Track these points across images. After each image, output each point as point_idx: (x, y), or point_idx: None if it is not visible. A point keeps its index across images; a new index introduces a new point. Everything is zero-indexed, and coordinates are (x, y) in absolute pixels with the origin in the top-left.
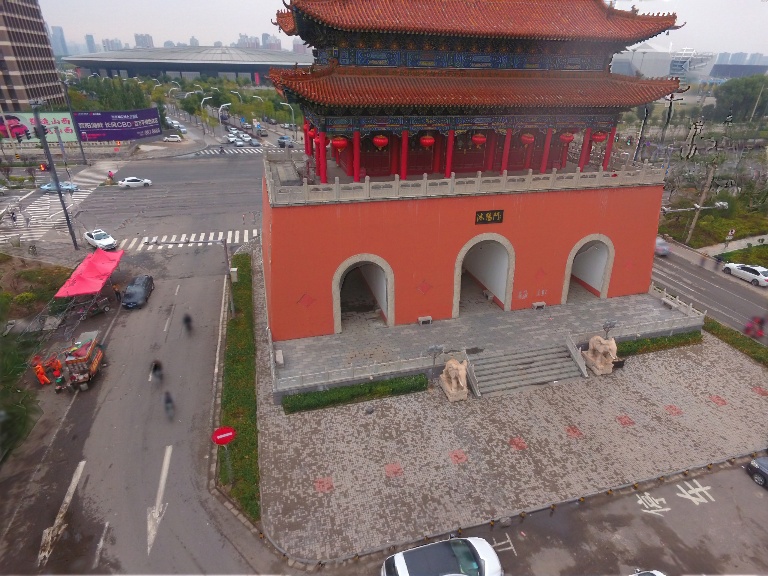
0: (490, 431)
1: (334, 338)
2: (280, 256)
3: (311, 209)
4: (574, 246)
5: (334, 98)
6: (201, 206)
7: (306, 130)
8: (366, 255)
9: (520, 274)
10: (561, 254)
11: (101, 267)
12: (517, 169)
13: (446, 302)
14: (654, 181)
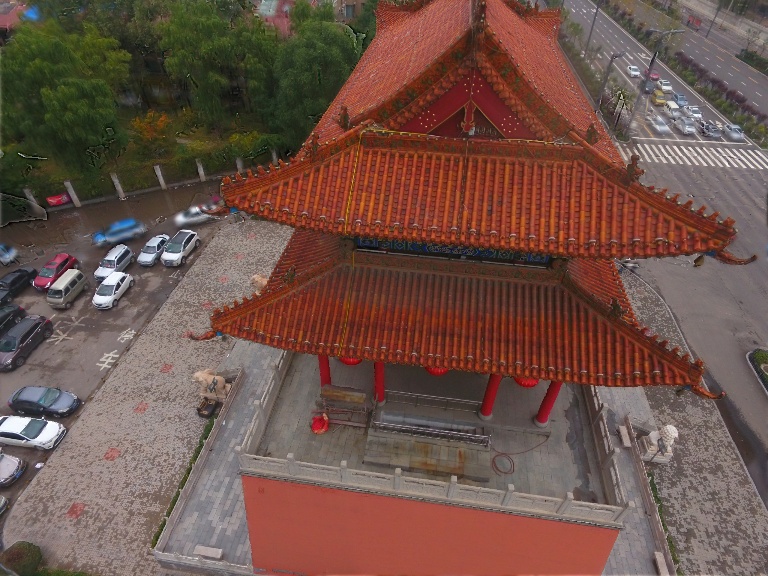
0: (225, 298)
1: None
2: None
3: None
4: None
5: None
6: None
7: None
8: None
9: None
10: None
11: None
12: None
13: None
14: None
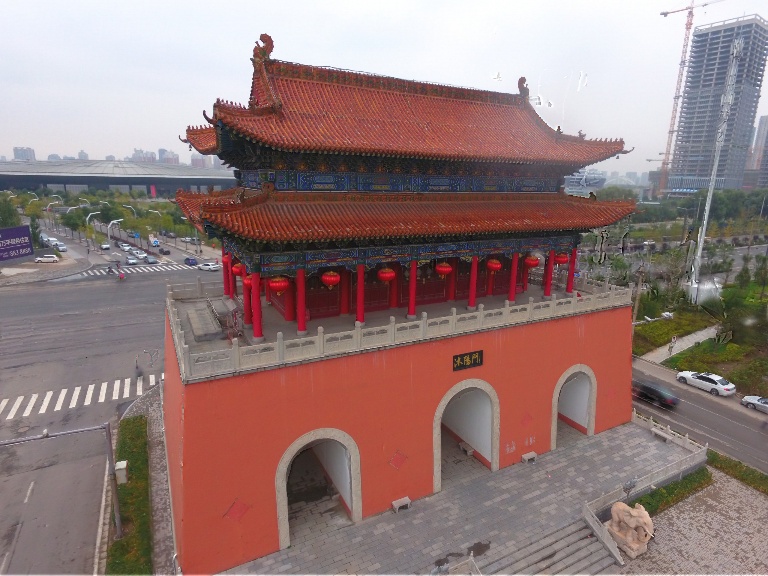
0: None
1: (280, 560)
2: (197, 452)
3: (244, 379)
4: (558, 381)
5: (274, 232)
6: (78, 346)
7: (226, 263)
8: (321, 431)
9: (505, 423)
10: (545, 392)
11: None
12: (479, 296)
13: (425, 474)
14: (623, 302)
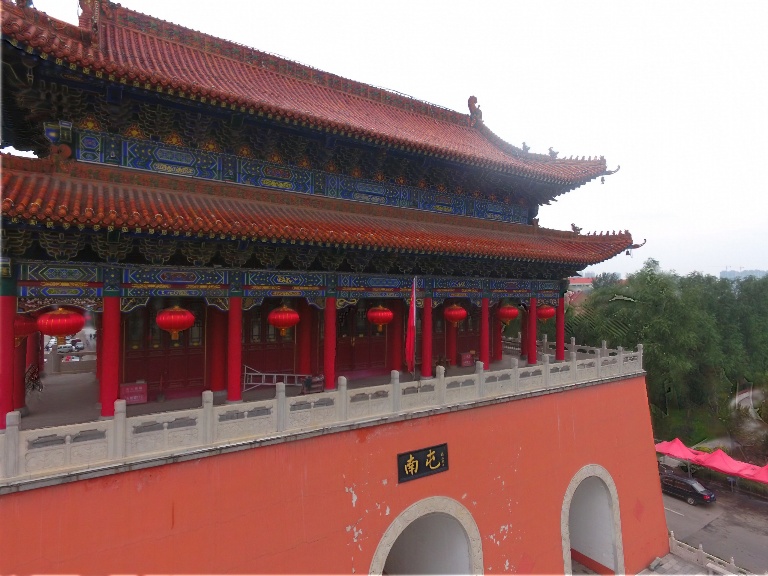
0: None
1: None
2: None
3: None
4: None
5: None
6: None
7: None
8: None
9: None
10: None
11: (713, 459)
12: None
13: None
14: None
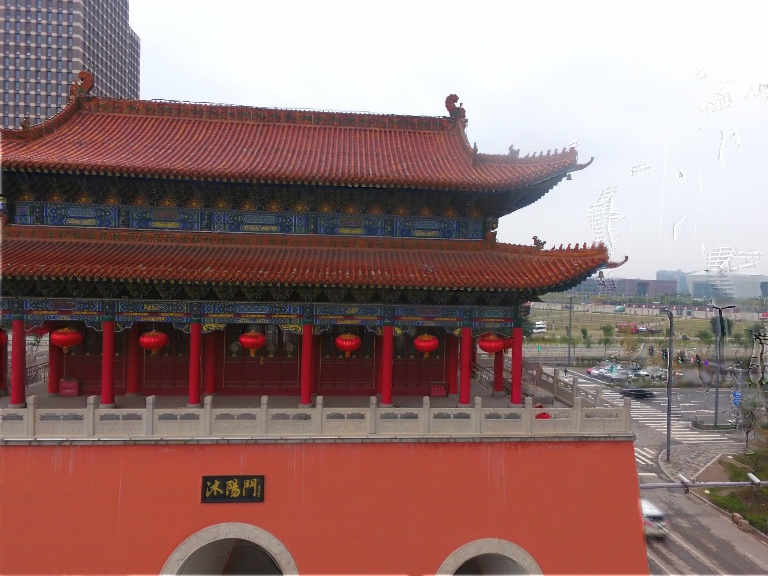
0: None
1: None
2: None
3: None
4: (441, 564)
5: None
6: None
7: None
8: None
9: None
10: None
11: None
12: (364, 393)
13: None
14: (608, 431)
